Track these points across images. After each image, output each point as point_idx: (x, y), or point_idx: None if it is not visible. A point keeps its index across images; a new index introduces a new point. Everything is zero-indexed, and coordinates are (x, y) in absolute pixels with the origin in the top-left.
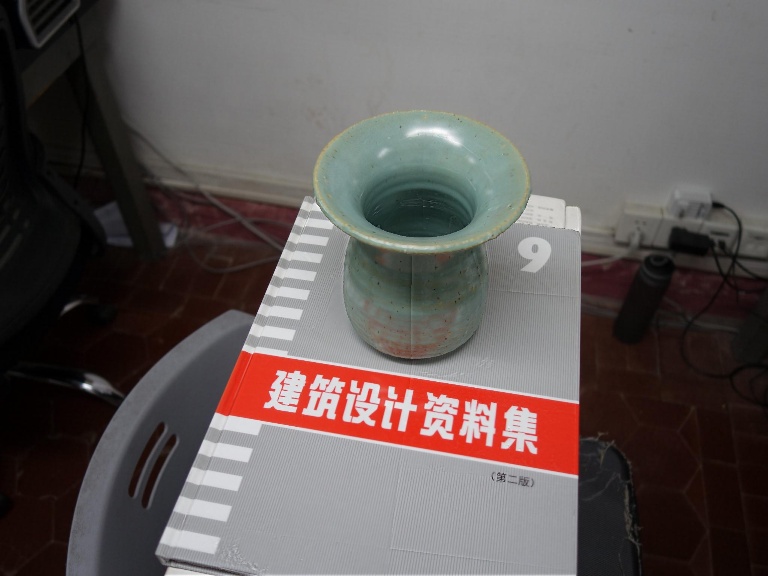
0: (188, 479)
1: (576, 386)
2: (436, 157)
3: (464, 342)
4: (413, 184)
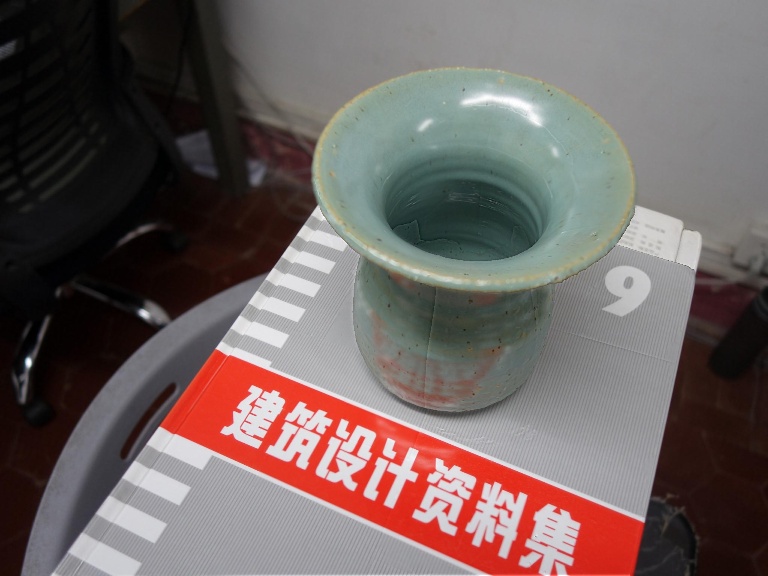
0: (100, 511)
1: (646, 494)
2: (506, 140)
3: (501, 399)
4: (469, 173)
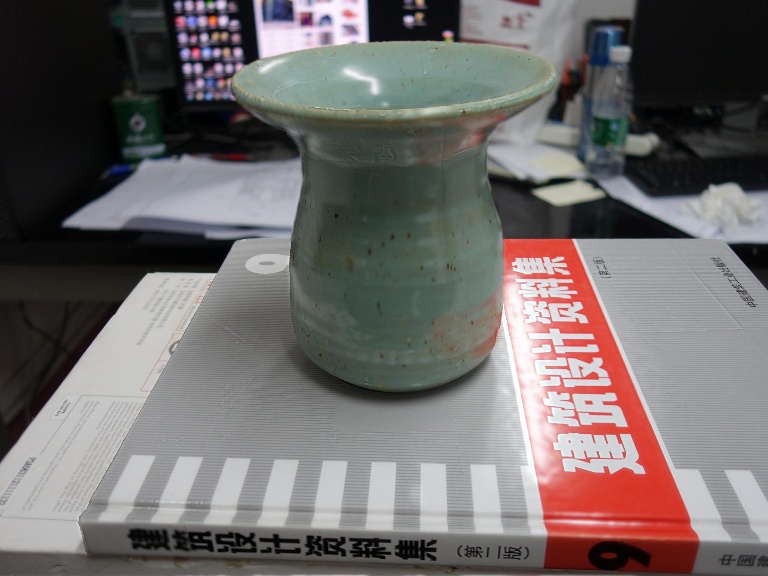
0: None
1: None
2: None
3: None
4: None
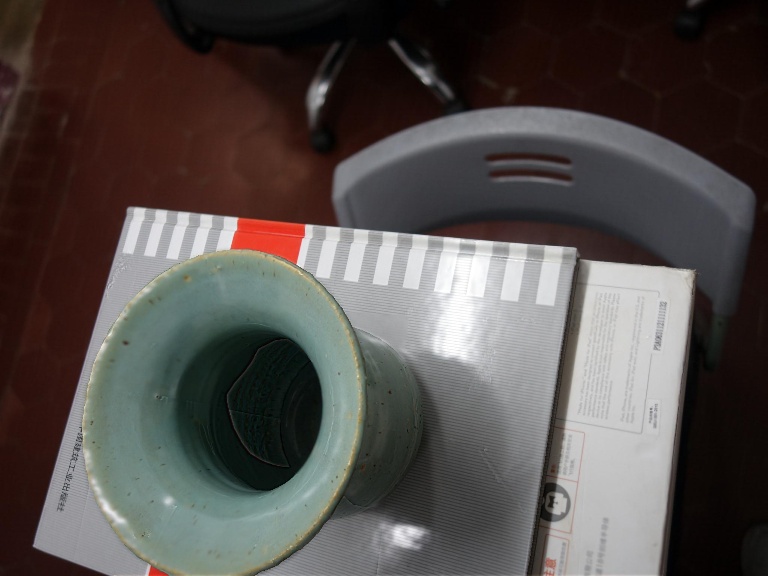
0: (180, 213)
1: None
2: None
3: None
4: None
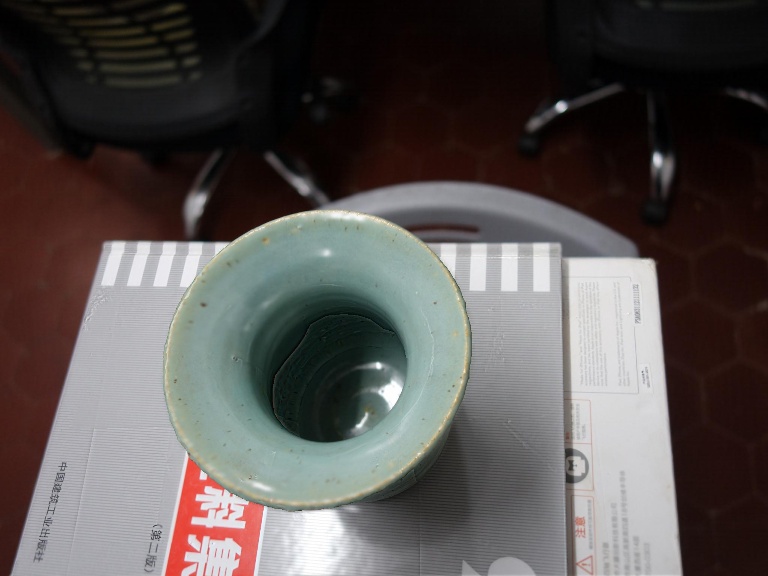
0: (166, 243)
1: None
2: (413, 370)
3: None
4: None
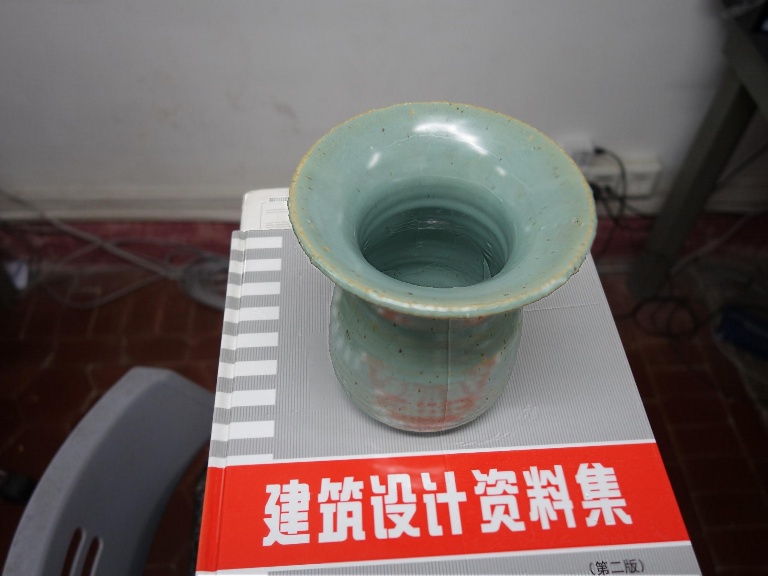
0: None
1: (644, 419)
2: (437, 164)
3: None
4: (407, 204)
